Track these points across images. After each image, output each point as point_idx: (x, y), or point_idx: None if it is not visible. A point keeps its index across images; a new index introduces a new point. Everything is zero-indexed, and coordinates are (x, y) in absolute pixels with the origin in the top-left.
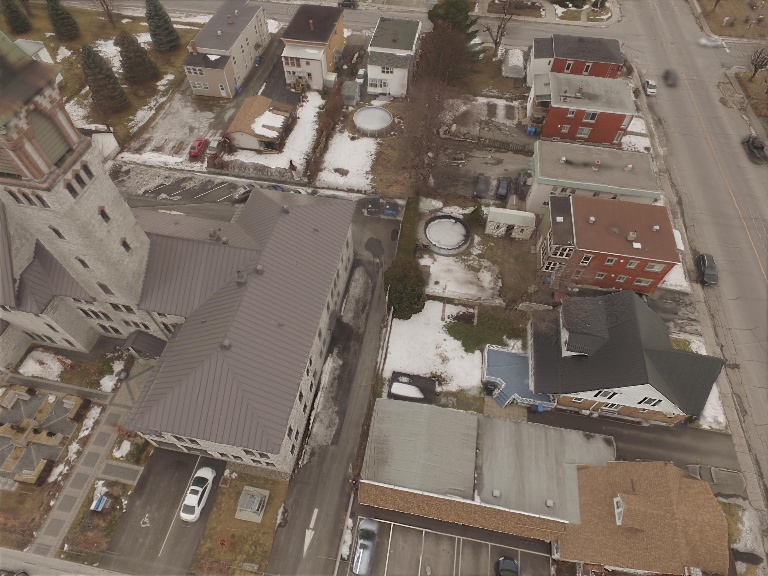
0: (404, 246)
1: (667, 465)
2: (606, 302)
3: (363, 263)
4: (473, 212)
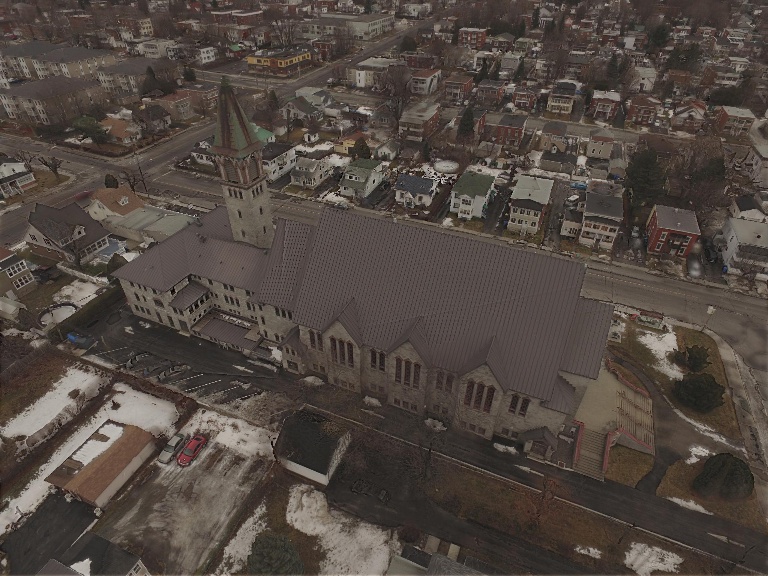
0: (98, 299)
1: (97, 198)
2: (44, 230)
3: (131, 310)
4: (27, 312)
